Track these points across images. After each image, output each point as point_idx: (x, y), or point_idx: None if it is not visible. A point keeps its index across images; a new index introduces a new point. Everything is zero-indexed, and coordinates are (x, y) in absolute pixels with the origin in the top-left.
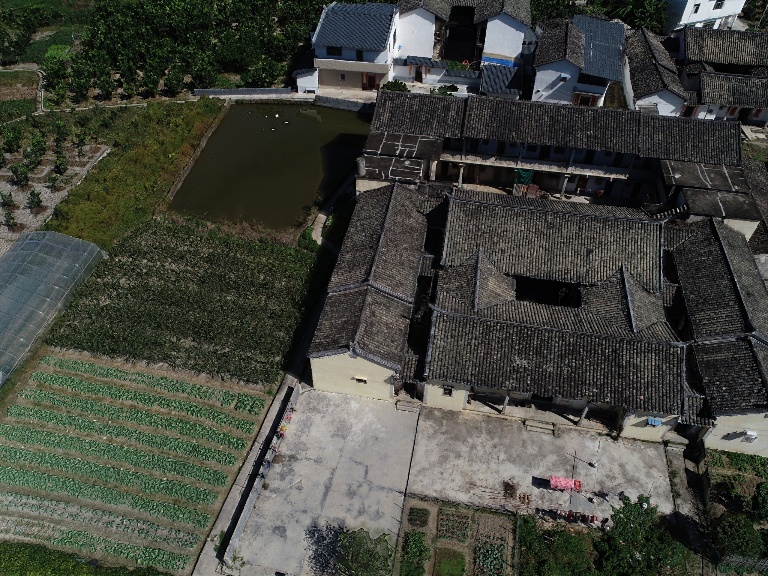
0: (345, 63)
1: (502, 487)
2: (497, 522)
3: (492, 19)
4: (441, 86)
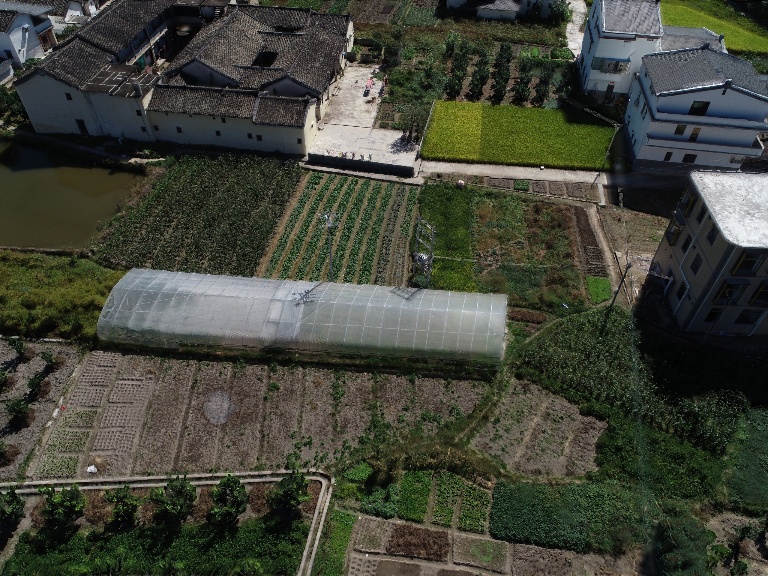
0: None
1: (368, 104)
2: (385, 106)
3: None
4: None
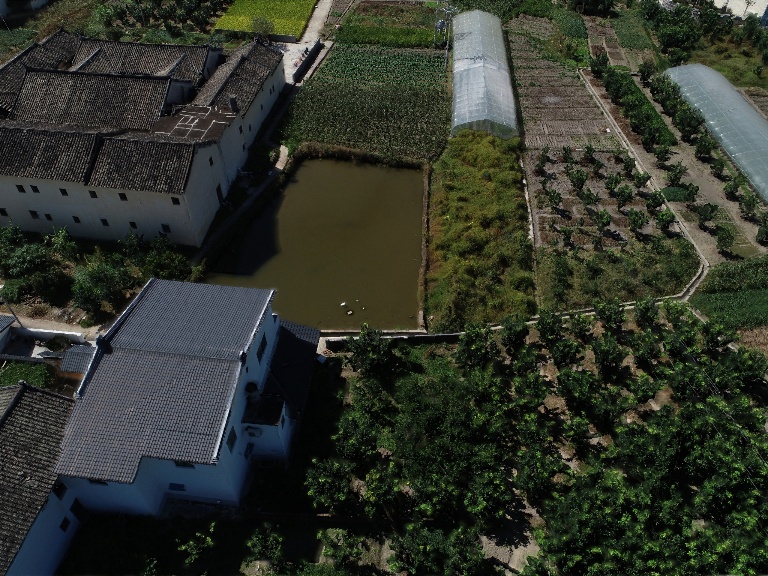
0: None
1: None
2: None
3: None
4: (85, 296)
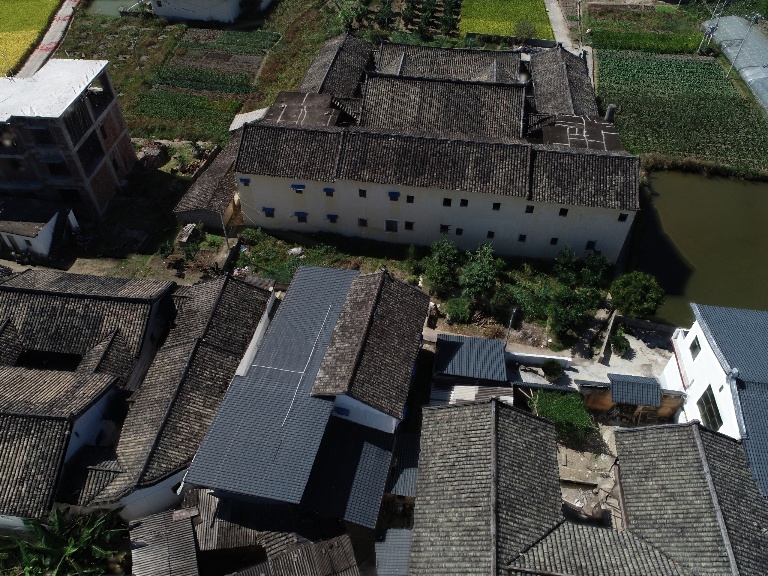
0: None
1: None
2: None
3: None
4: (572, 319)
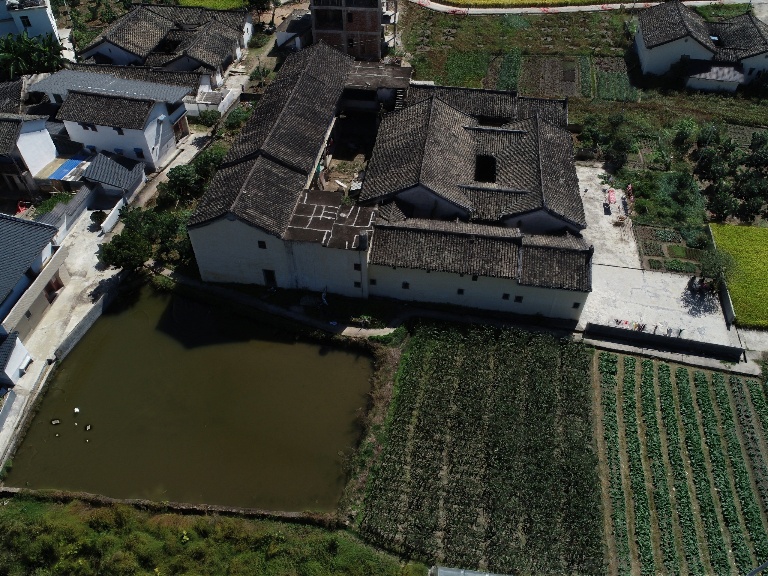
0: (31, 290)
1: (618, 227)
2: (642, 231)
3: (17, 137)
4: (119, 212)
